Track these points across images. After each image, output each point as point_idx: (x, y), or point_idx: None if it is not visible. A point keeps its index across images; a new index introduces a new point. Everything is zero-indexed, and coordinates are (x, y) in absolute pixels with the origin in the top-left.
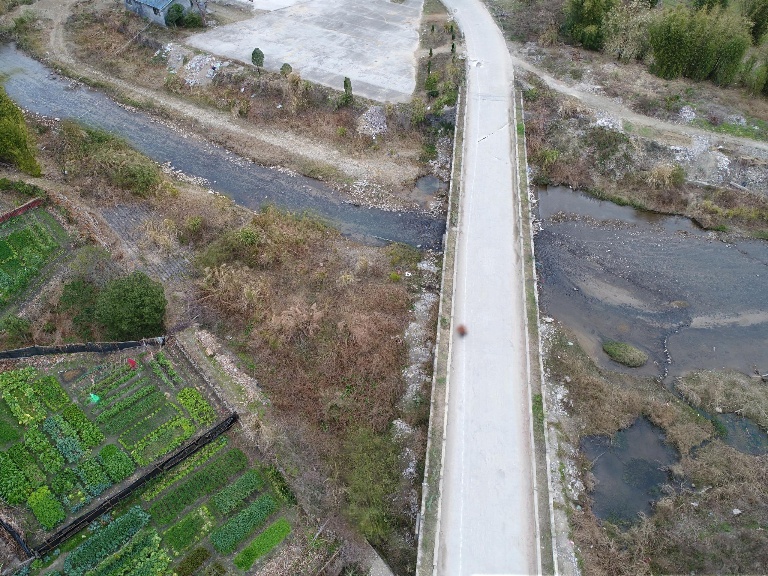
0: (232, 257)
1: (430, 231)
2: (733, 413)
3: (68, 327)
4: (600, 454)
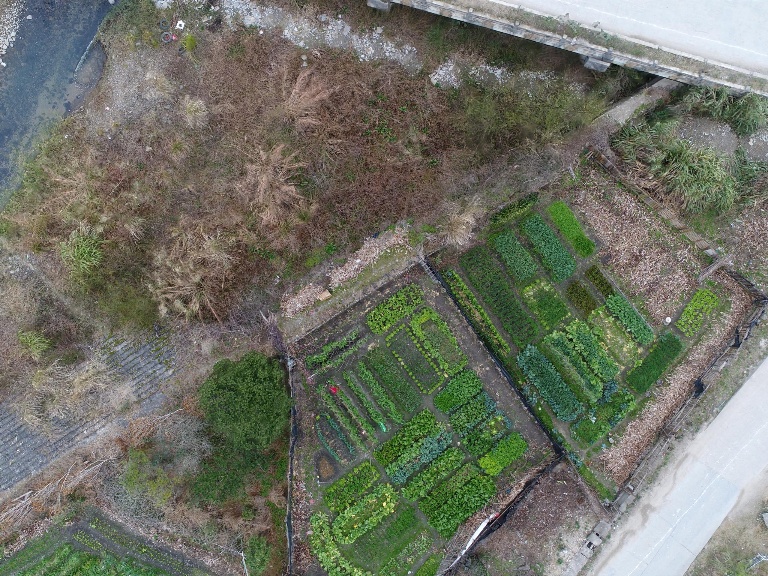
0: (125, 279)
1: None
2: None
3: (248, 489)
4: None
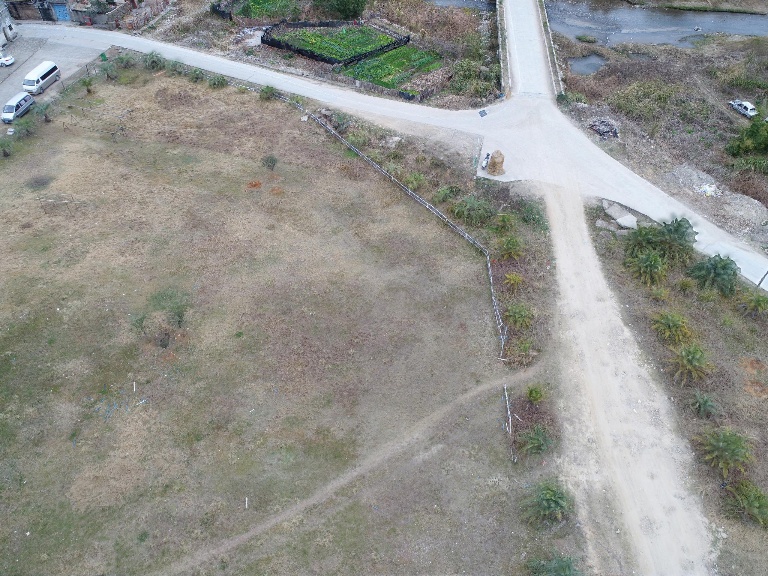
0: None
1: (482, 5)
2: (637, 53)
3: None
4: (574, 61)
